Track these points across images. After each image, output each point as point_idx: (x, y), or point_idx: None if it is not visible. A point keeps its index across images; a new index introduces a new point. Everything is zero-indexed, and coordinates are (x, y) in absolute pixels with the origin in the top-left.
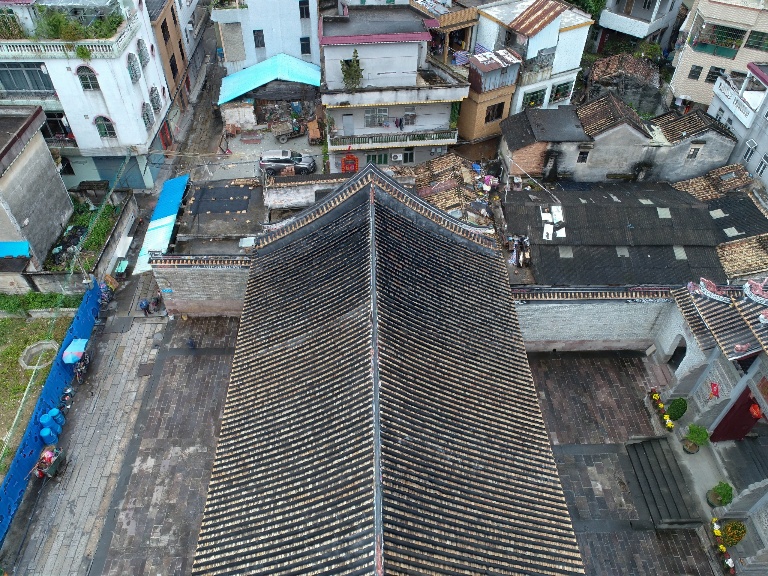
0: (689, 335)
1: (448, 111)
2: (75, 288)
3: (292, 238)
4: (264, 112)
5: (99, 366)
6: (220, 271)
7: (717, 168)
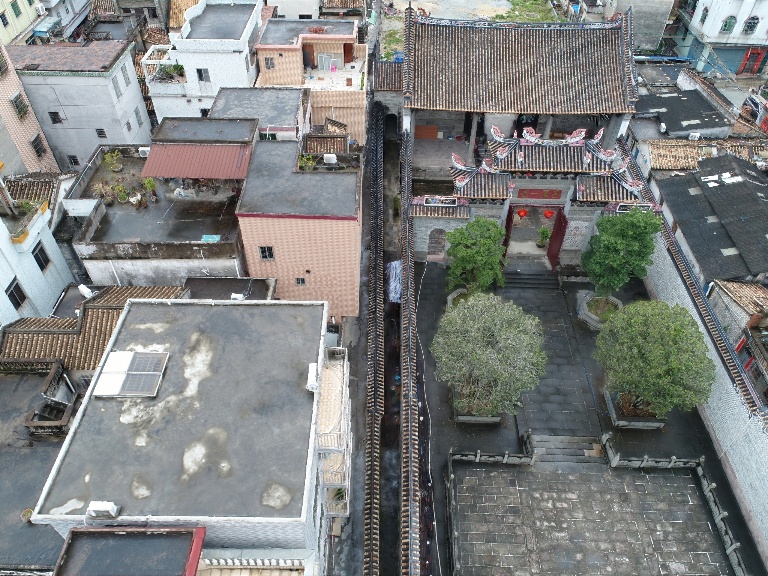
0: None
1: None
2: None
3: None
4: None
5: None
6: None
7: None
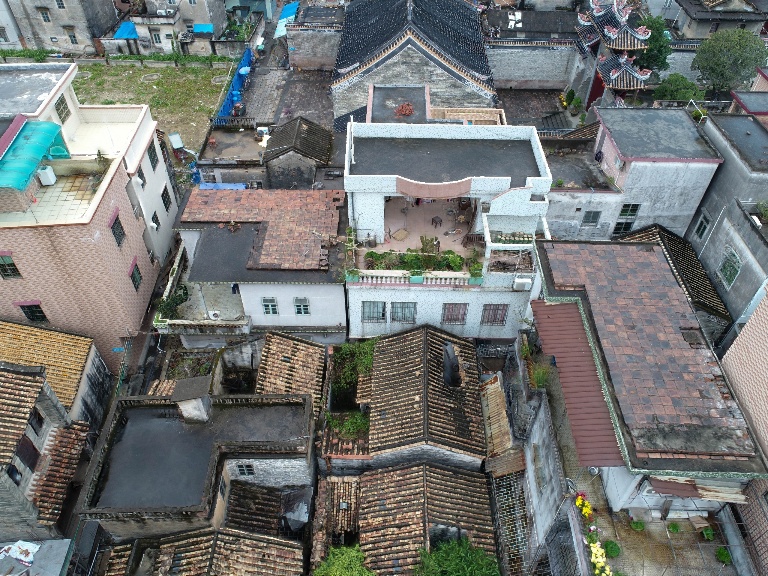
0: (580, 62)
1: None
2: (237, 53)
3: None
4: None
5: (255, 85)
6: (323, 34)
7: None
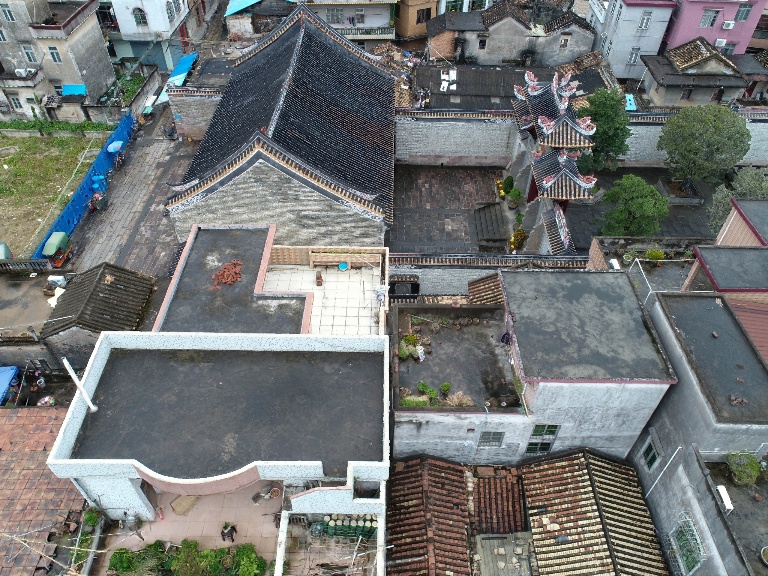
0: None
1: (388, 13)
2: (116, 119)
3: (256, 59)
4: (260, 25)
5: (130, 162)
6: (213, 100)
7: (582, 55)
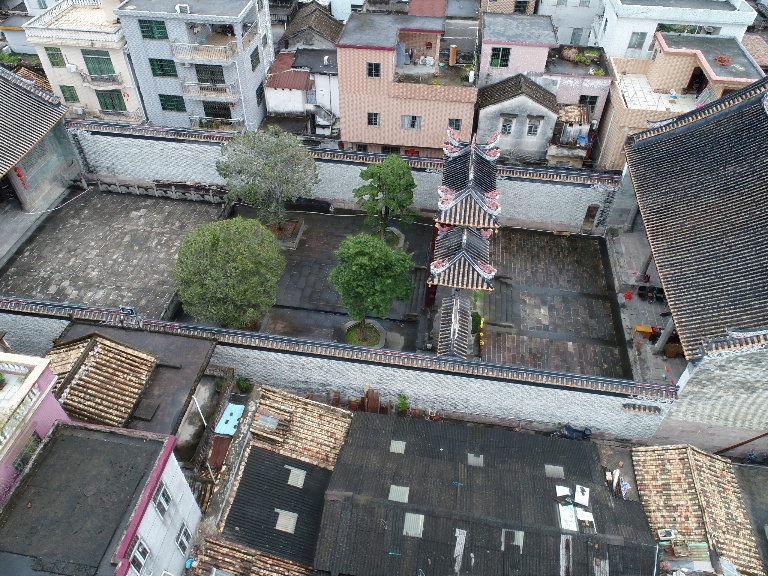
0: None
1: None
2: None
3: None
4: None
5: None
6: None
7: None
